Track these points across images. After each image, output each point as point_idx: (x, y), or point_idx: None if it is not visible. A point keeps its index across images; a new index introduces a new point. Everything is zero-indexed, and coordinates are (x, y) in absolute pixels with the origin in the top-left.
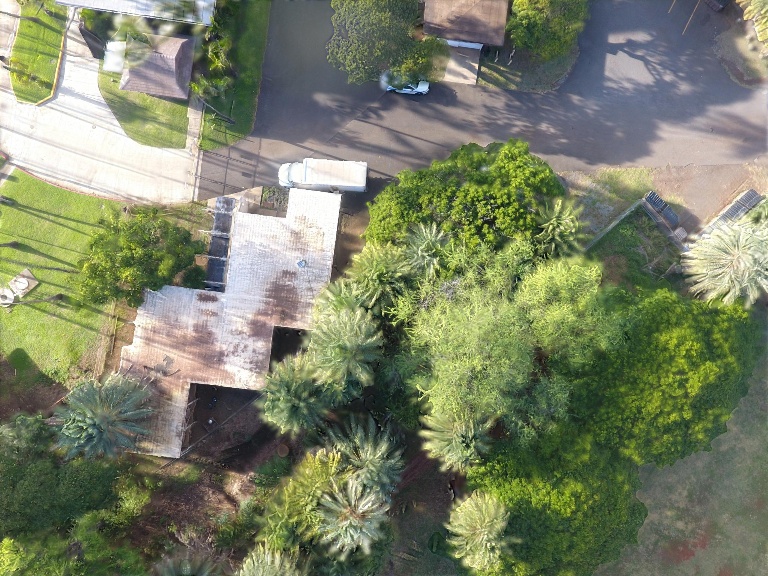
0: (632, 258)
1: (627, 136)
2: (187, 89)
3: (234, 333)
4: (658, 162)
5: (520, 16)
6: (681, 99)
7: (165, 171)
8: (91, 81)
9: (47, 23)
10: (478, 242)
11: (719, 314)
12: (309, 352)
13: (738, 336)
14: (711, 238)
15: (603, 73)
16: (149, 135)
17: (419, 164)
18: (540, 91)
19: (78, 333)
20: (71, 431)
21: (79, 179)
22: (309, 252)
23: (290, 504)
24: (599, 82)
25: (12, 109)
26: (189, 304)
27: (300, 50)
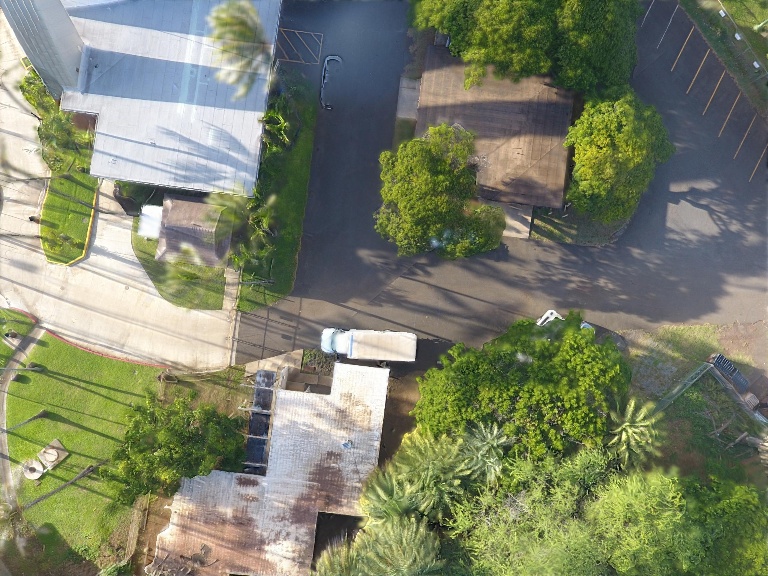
0: (698, 424)
1: (691, 291)
2: (226, 258)
3: (276, 520)
4: (724, 319)
5: (582, 186)
6: (748, 251)
7: (201, 334)
8: (124, 240)
9: (79, 180)
10: (545, 452)
11: None
12: (357, 545)
13: None
14: None
15: (664, 224)
16: (184, 296)
17: (469, 324)
18: (597, 244)
19: (109, 507)
20: None
21: (111, 343)
22: (355, 432)
23: None
24: (660, 234)
25: (42, 269)
26: (228, 489)
27: (342, 204)
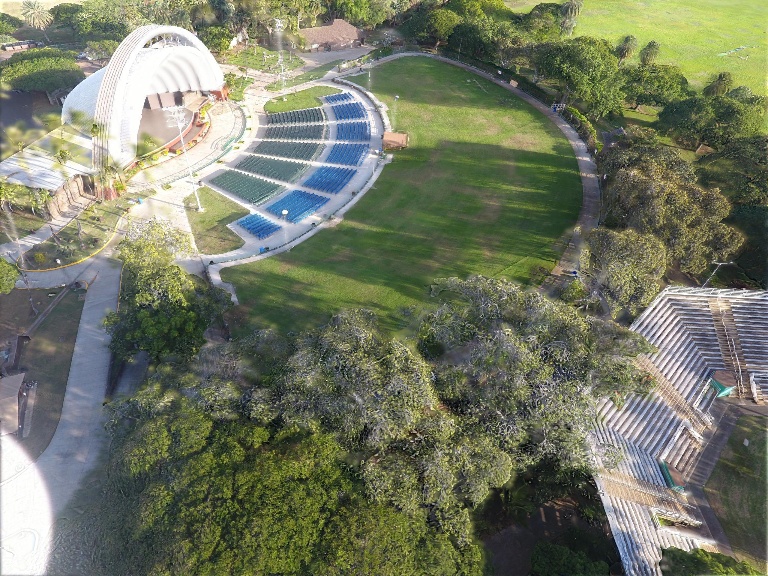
0: None
1: None
2: None
3: None
4: None
5: None
6: None
7: None
8: None
9: None
10: None
11: None
12: None
13: None
14: None
15: None
16: None
17: None
18: None
19: None
20: (231, 4)
21: None
22: None
23: (188, 5)
24: None
25: None
26: None
27: None
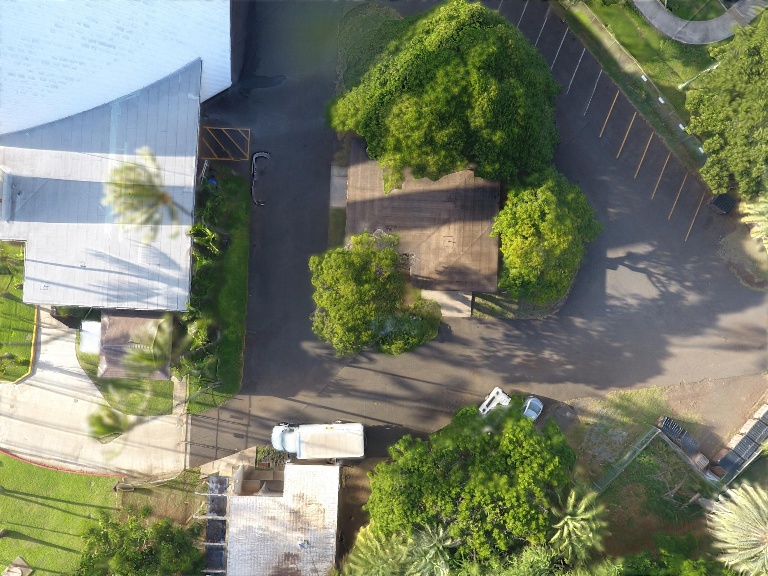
0: (652, 487)
1: (635, 355)
2: (168, 370)
3: None
4: (671, 380)
5: (513, 275)
6: (690, 310)
7: (153, 440)
8: (69, 353)
9: (18, 297)
10: (489, 553)
11: None
12: None
13: None
14: (738, 506)
15: (604, 291)
16: (134, 404)
17: (418, 407)
18: (539, 316)
19: None
20: None
21: (65, 456)
22: (310, 531)
23: None
24: (601, 300)
25: None
26: None
27: (283, 298)
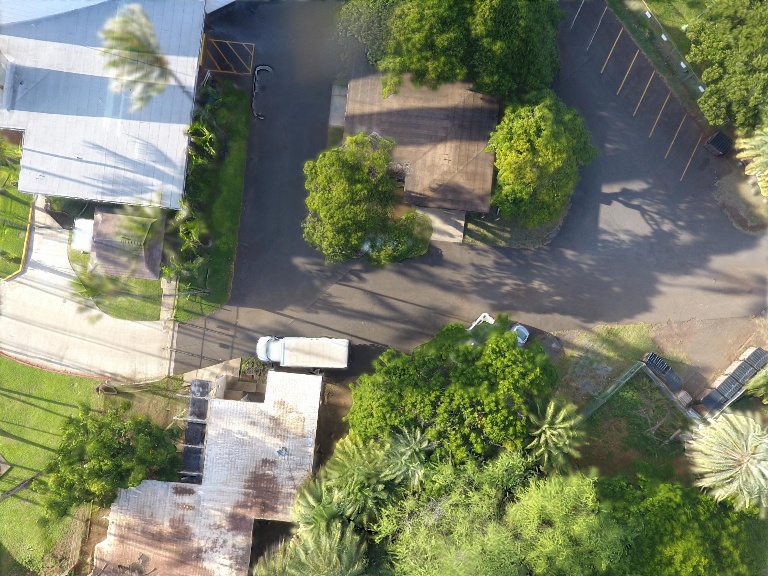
0: (633, 422)
1: (624, 291)
2: (158, 270)
3: (212, 527)
4: (658, 318)
5: (505, 191)
6: (681, 249)
7: (139, 345)
8: (61, 253)
9: (14, 195)
10: (465, 455)
11: (728, 513)
12: (291, 551)
13: (750, 536)
14: (717, 430)
15: (597, 225)
16: (122, 308)
17: (405, 329)
18: (530, 246)
19: (52, 519)
20: None
21: (50, 356)
22: (289, 439)
23: None
24: (593, 234)
25: None
26: (164, 498)
27: (277, 212)
